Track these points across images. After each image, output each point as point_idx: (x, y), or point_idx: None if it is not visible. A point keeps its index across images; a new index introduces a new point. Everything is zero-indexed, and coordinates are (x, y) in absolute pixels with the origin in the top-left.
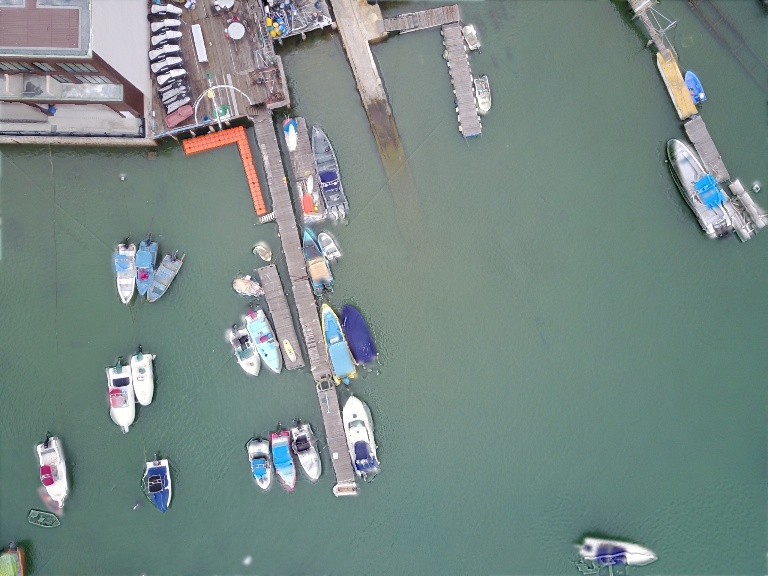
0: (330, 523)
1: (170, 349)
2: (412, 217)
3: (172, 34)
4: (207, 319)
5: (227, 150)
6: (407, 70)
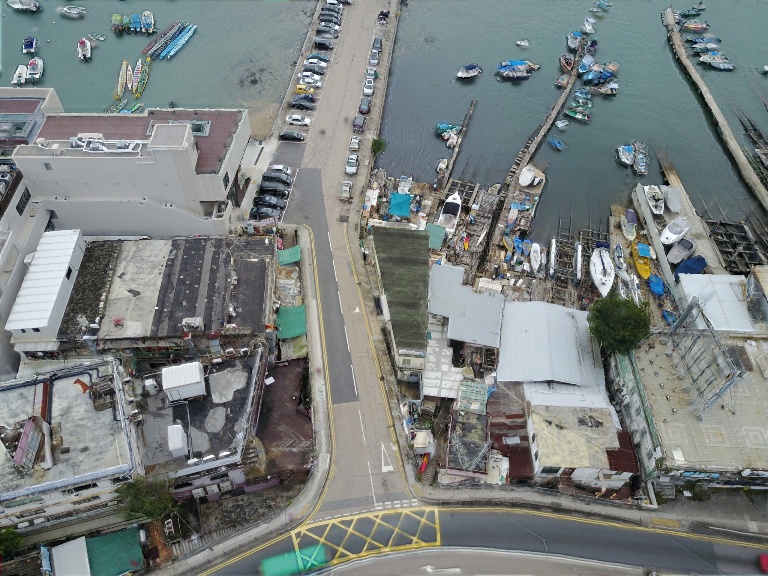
0: None
1: None
2: None
3: None
4: None
5: None
6: None
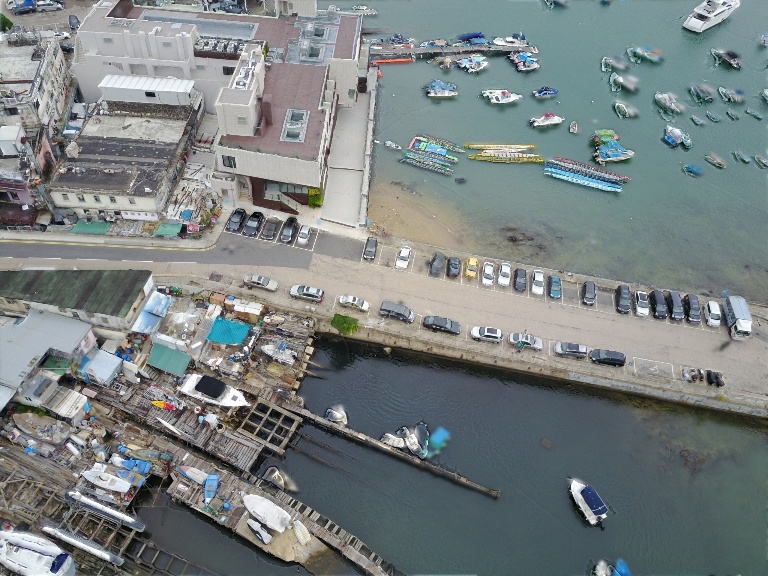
0: (551, 54)
1: None
2: None
3: None
4: None
5: None
6: None
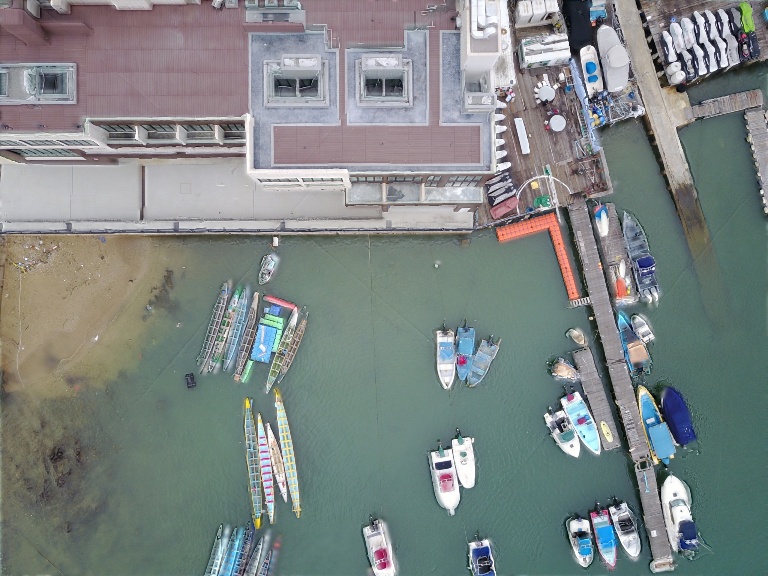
0: None
1: (486, 431)
2: (717, 297)
3: (500, 129)
4: (520, 401)
5: (538, 236)
6: (709, 153)
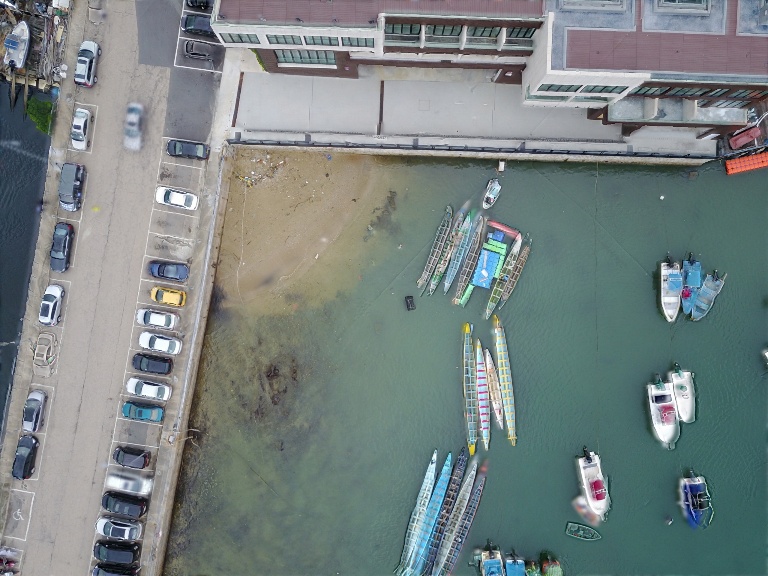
0: None
1: (705, 367)
2: None
3: None
4: (740, 338)
5: (767, 171)
6: None
